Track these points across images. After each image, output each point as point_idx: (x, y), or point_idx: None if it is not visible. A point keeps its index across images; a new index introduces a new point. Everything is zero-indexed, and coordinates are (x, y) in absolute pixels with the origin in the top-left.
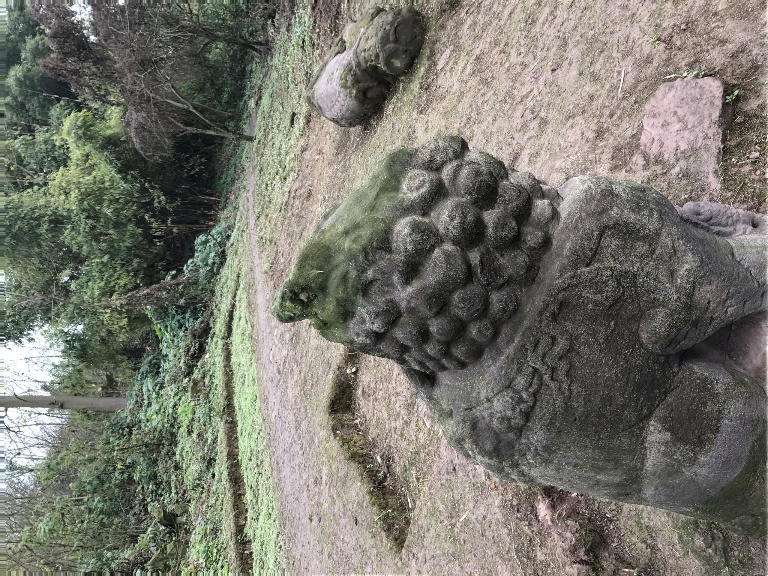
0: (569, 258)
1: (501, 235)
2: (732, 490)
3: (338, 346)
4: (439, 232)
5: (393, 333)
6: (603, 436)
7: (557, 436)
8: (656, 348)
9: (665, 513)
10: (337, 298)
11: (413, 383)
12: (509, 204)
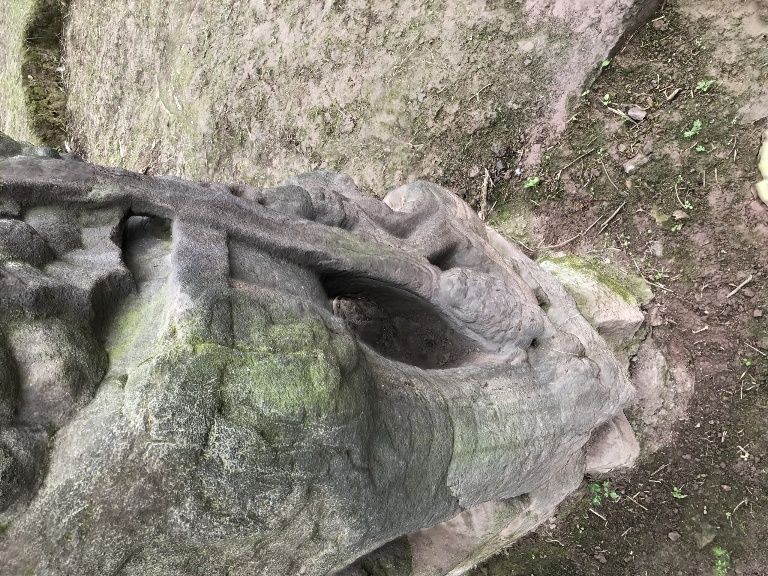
0: None
1: None
2: None
3: None
4: None
5: None
6: None
7: None
8: None
9: None
10: None
11: None
12: None
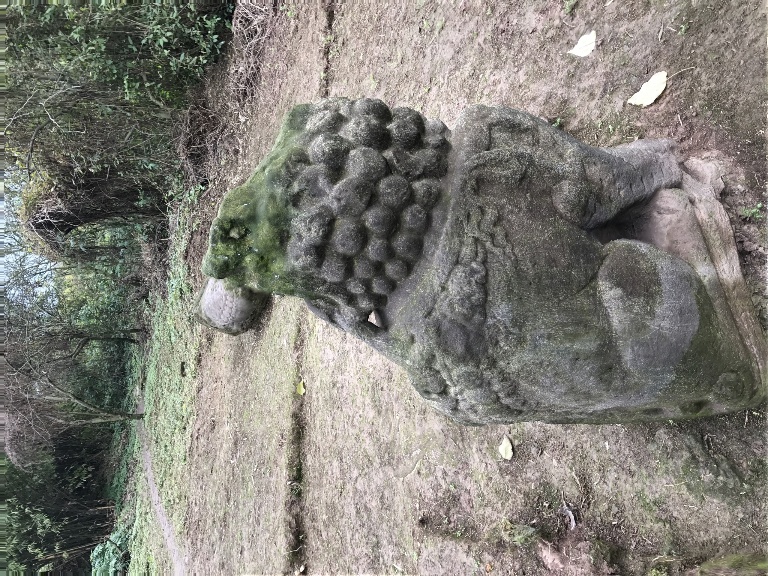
0: (469, 146)
1: (404, 132)
2: (701, 344)
3: (278, 550)
4: (349, 140)
5: (331, 247)
6: (562, 298)
7: (520, 304)
8: (574, 217)
9: (664, 473)
10: (268, 216)
11: (366, 337)
12: (403, 119)
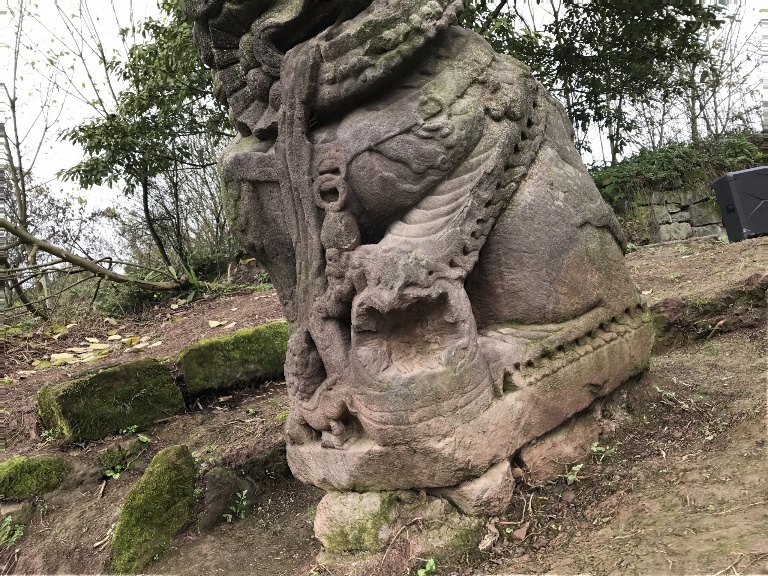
0: None
1: None
2: None
3: None
4: None
5: None
6: None
7: None
8: None
9: (659, 361)
10: None
11: None
12: None
